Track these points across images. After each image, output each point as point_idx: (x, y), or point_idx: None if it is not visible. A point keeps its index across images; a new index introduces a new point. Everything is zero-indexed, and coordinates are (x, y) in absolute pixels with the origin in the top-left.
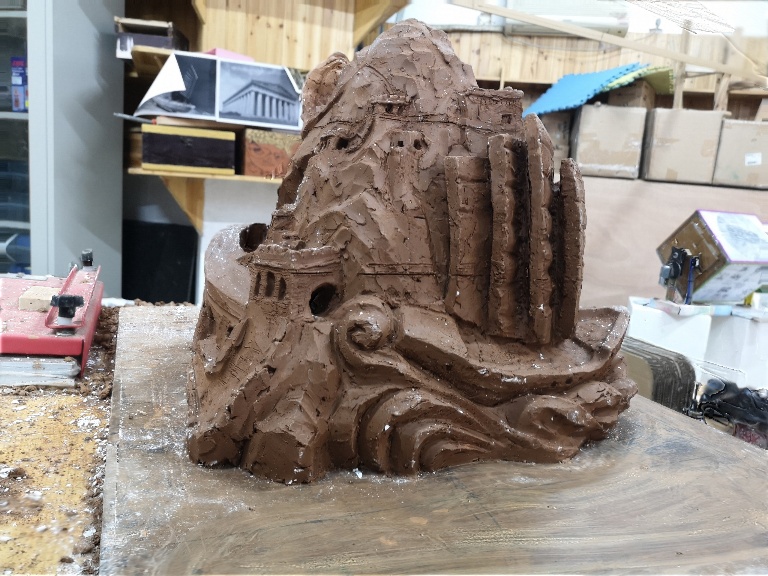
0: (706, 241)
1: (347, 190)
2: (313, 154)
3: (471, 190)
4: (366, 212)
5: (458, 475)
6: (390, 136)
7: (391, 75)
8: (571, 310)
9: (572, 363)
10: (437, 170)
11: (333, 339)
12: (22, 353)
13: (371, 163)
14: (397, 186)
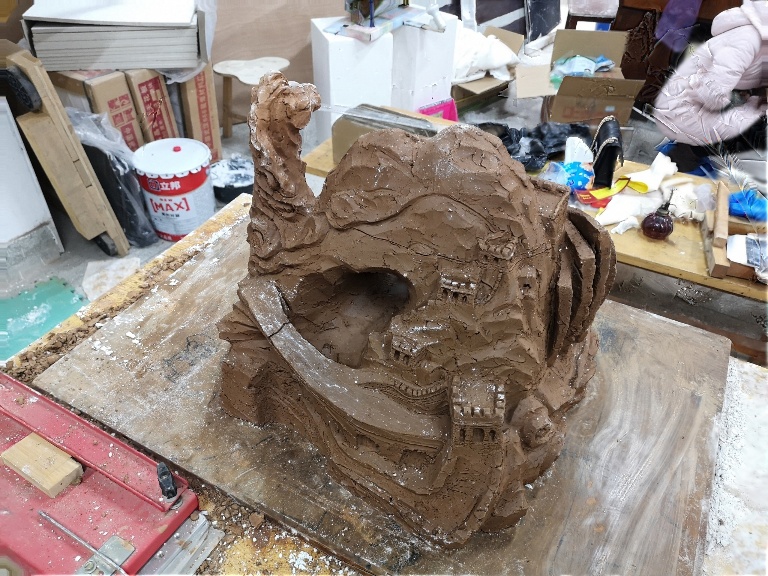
0: None
1: (497, 336)
2: (392, 270)
3: None
4: (525, 354)
5: None
6: None
7: (491, 216)
8: None
9: None
10: None
11: None
12: (160, 546)
13: (518, 315)
14: (533, 320)
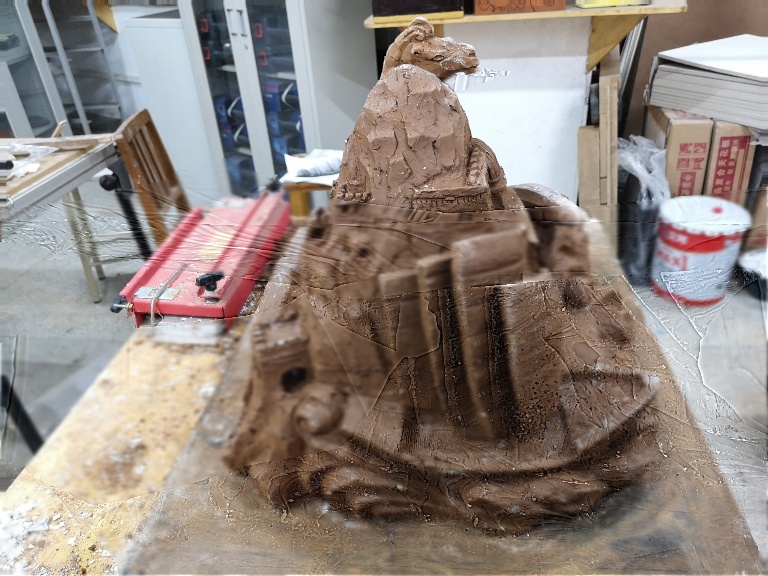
0: None
1: None
2: None
3: None
4: None
5: None
6: None
7: None
8: None
9: None
10: None
11: None
12: (186, 315)
13: None
14: None
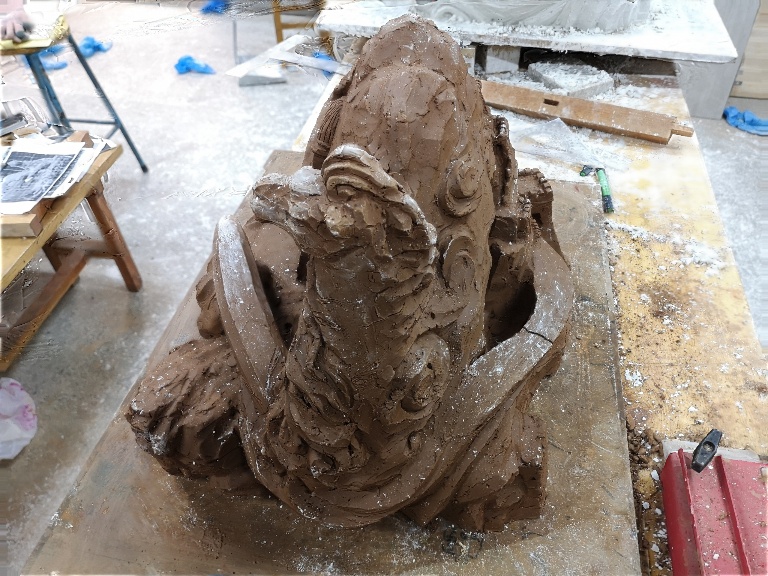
0: None
1: None
2: None
3: None
4: None
5: None
6: None
7: None
8: None
9: None
10: None
11: None
12: None
13: None
14: None
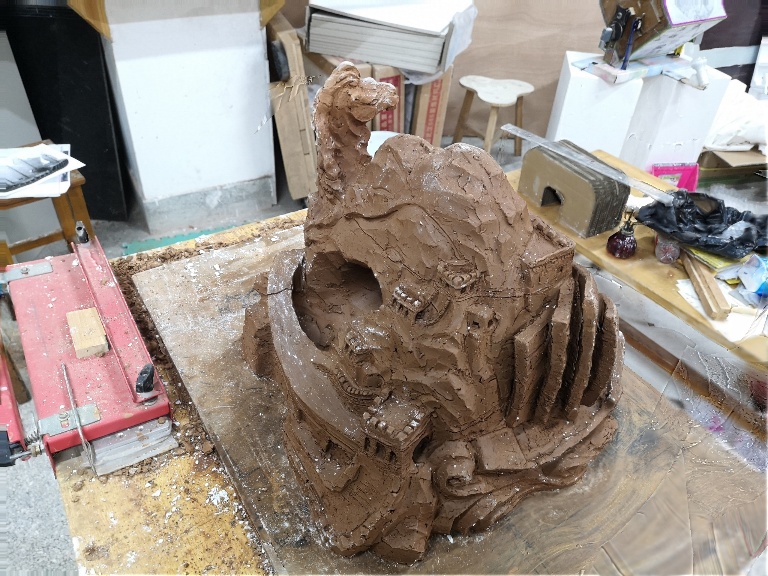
0: (652, 0)
1: (431, 363)
2: None
3: (535, 357)
4: (453, 392)
5: (513, 520)
6: (466, 317)
7: (458, 241)
8: (594, 397)
9: (587, 417)
10: (506, 339)
11: (433, 479)
12: (123, 429)
13: (454, 349)
14: (475, 362)
